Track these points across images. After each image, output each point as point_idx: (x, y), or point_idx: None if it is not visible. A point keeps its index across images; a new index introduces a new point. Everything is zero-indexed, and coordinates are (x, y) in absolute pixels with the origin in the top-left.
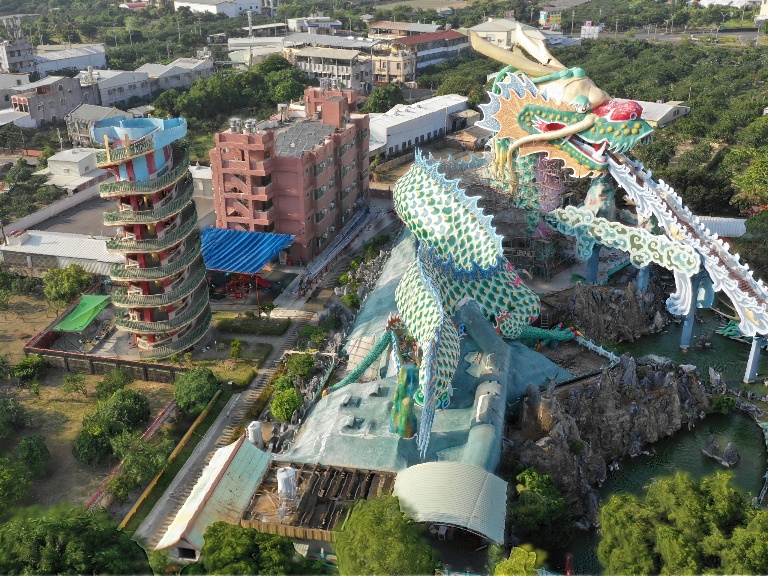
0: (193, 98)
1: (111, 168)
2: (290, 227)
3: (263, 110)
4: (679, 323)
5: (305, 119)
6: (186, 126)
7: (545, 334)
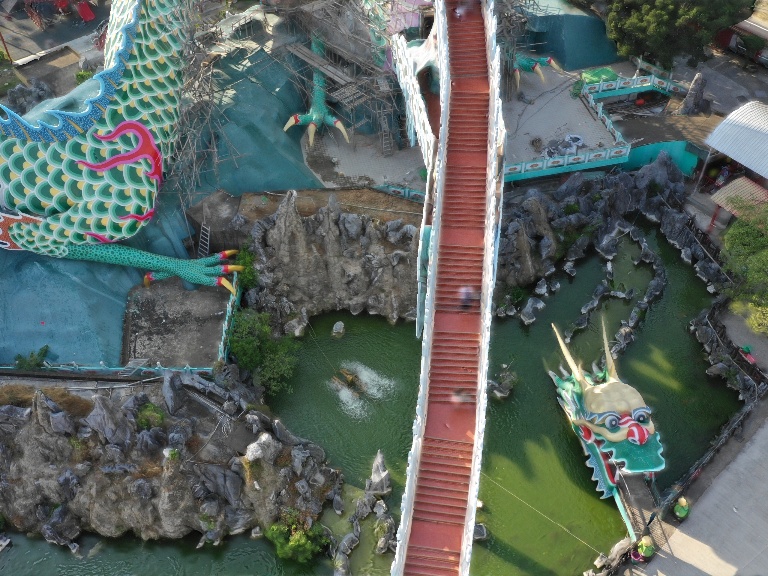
0: None
1: None
2: None
3: None
4: (525, 323)
5: None
6: None
7: (152, 264)
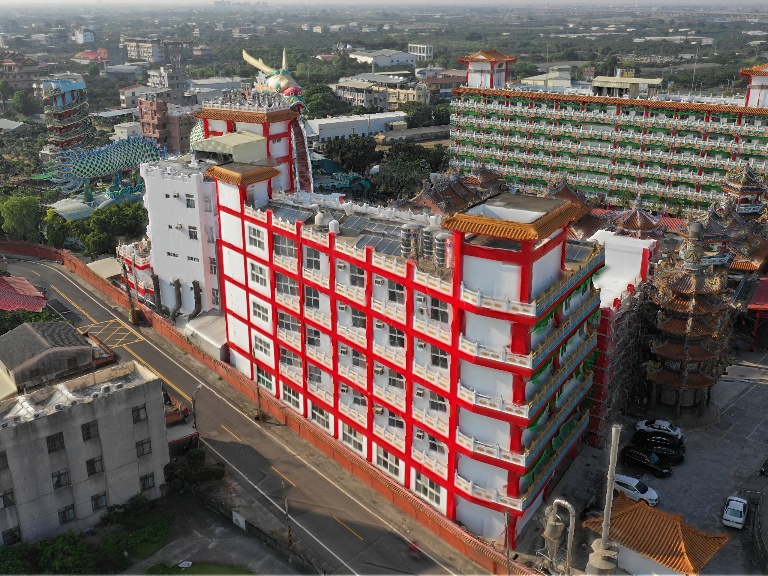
0: None
1: (51, 102)
2: (175, 155)
3: None
4: None
5: None
6: (82, 85)
7: None
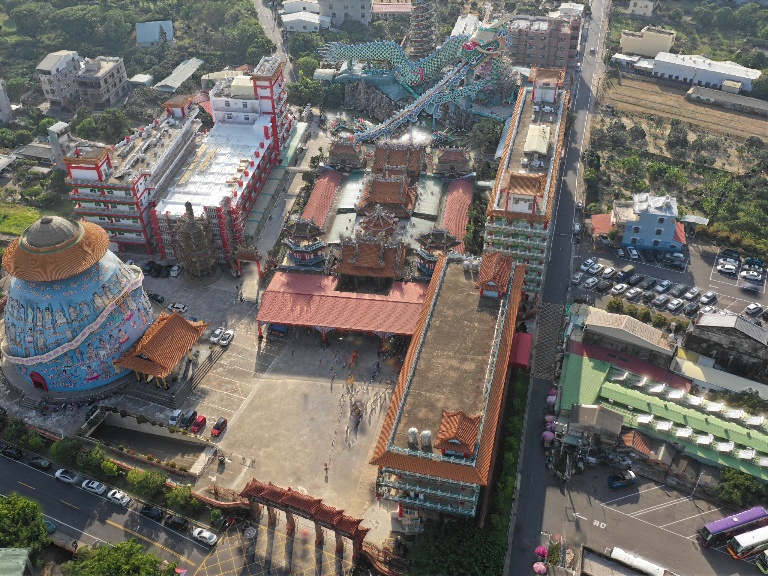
0: (704, 10)
1: None
2: None
3: (738, 36)
4: None
5: (566, 24)
6: None
7: None
